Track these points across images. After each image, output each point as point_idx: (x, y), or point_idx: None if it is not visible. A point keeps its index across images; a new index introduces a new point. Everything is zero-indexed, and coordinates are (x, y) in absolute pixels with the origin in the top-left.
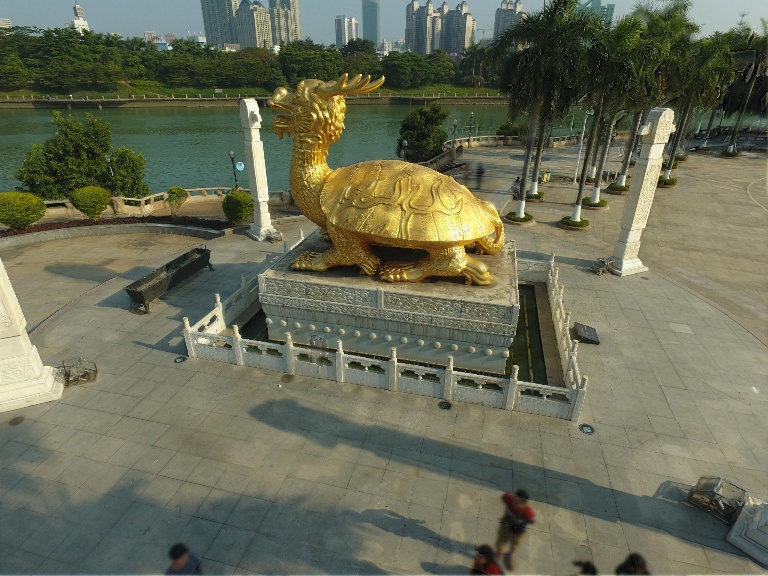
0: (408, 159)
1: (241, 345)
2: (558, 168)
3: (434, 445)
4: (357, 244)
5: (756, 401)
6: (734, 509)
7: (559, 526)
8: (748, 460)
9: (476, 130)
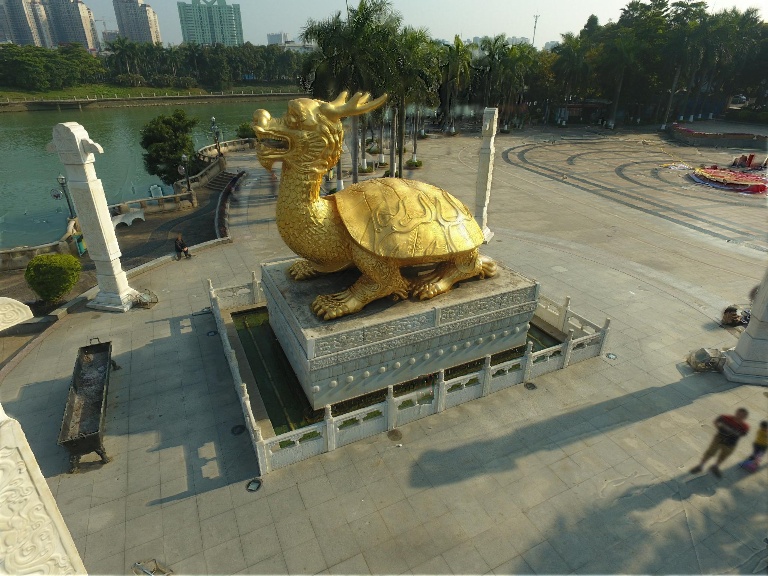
0: (160, 175)
1: (335, 425)
2: None
3: (566, 418)
4: (398, 270)
5: (641, 299)
6: (717, 362)
7: (682, 423)
8: (681, 334)
9: (221, 135)
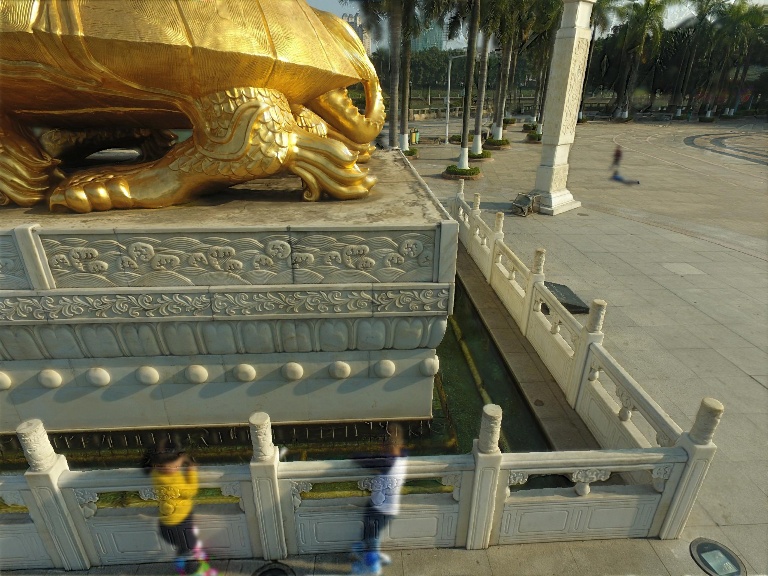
0: None
1: None
2: (425, 132)
3: None
4: None
5: None
6: None
7: None
8: None
9: None
